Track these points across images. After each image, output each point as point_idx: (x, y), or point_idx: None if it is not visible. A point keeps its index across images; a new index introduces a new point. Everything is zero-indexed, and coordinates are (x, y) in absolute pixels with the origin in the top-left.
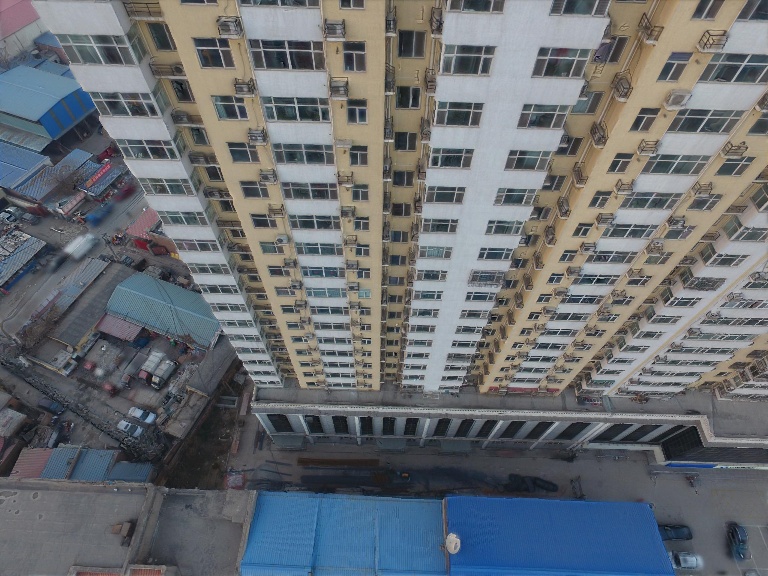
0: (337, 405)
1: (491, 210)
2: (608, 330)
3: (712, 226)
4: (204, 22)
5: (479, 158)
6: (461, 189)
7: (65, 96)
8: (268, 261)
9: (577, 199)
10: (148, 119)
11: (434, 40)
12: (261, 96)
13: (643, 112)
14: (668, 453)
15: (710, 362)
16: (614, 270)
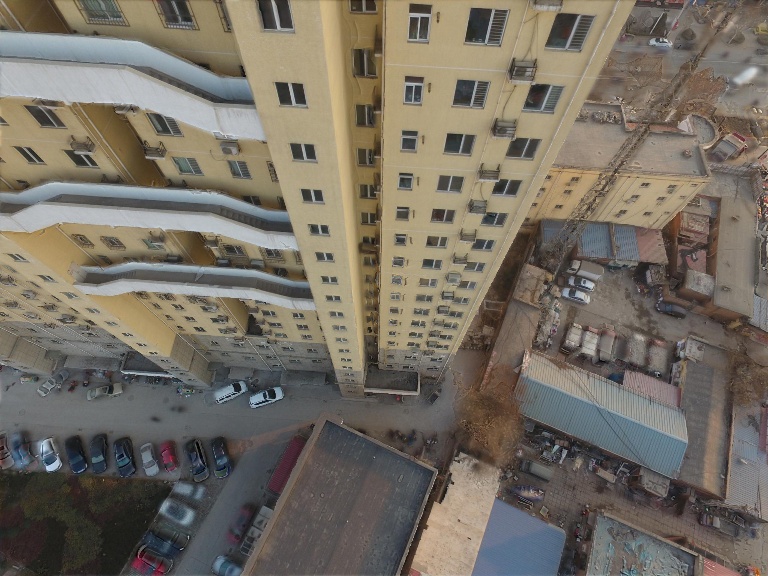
0: None
1: None
2: None
3: None
4: None
5: None
6: None
7: None
8: None
9: None
10: None
11: None
12: None
13: None
14: None
15: None
16: None
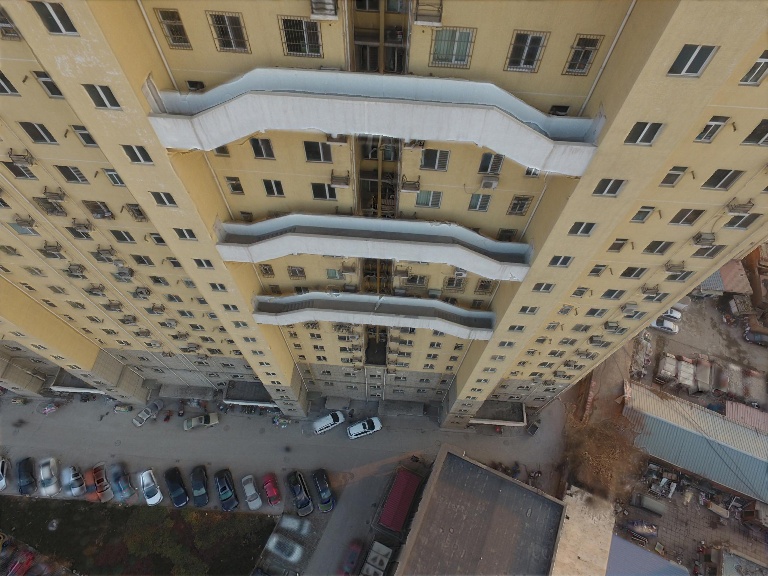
0: None
1: None
2: None
3: None
4: None
5: None
6: None
7: None
8: None
9: None
10: None
11: None
12: None
13: None
14: None
15: None
16: None
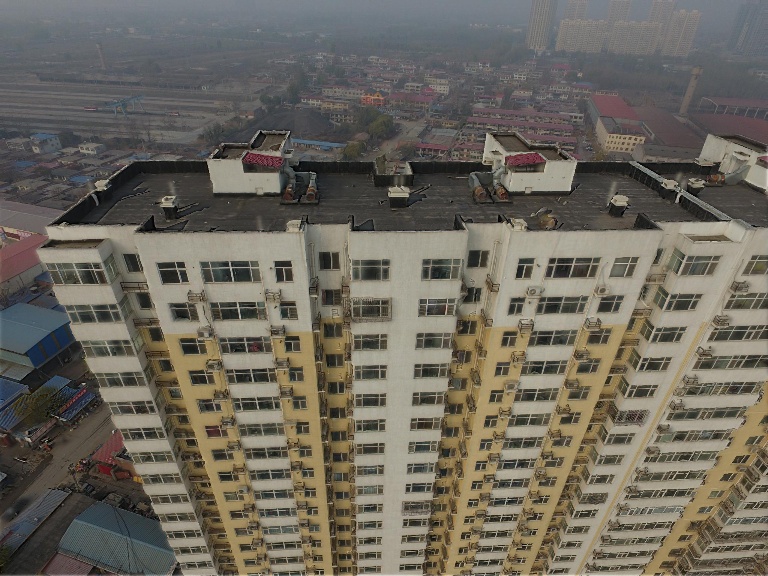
0: None
1: (407, 457)
2: (534, 543)
3: (581, 453)
4: (197, 363)
5: (390, 424)
6: (382, 444)
7: (55, 329)
8: (230, 507)
9: (469, 445)
10: (148, 415)
11: None
12: (232, 398)
13: (494, 392)
14: None
15: (636, 565)
16: (517, 493)
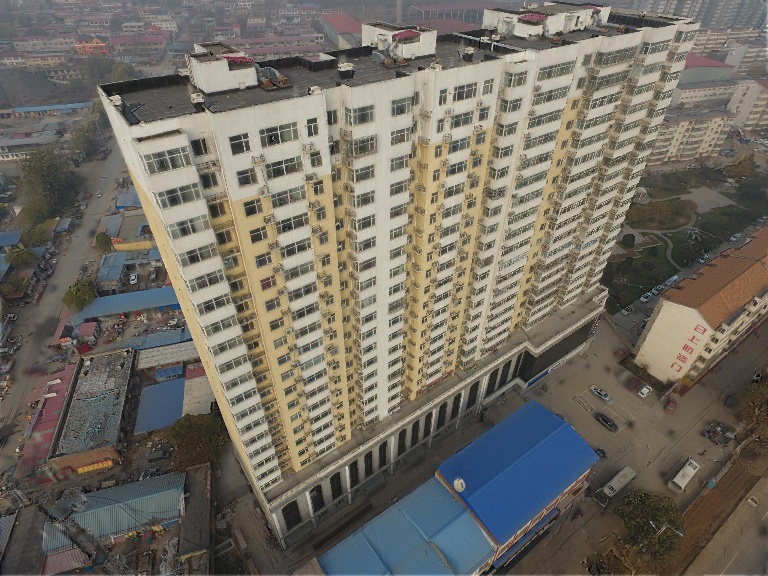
0: (331, 464)
1: (389, 264)
2: (460, 311)
3: None
4: (256, 222)
5: (379, 239)
6: (374, 258)
7: None
8: (278, 354)
9: (423, 242)
10: (219, 284)
11: (347, 196)
12: (280, 247)
13: (433, 195)
14: (524, 378)
15: (511, 307)
16: (450, 272)
